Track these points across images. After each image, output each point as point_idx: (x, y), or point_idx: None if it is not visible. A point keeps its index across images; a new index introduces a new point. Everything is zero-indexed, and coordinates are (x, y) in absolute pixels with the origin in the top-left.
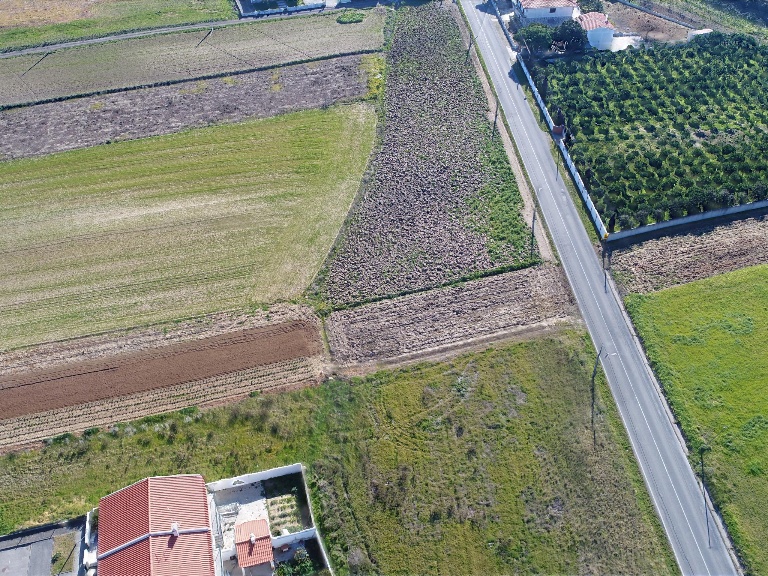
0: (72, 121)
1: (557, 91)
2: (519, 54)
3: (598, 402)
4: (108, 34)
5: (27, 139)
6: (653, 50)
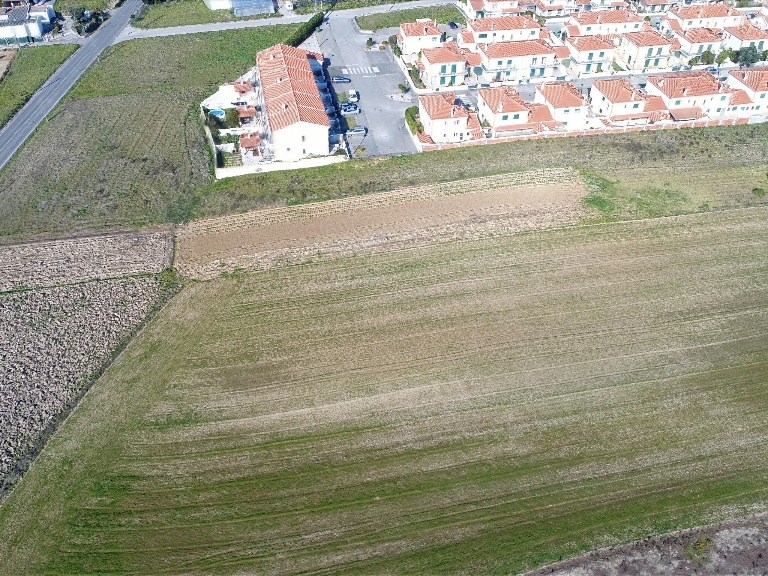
0: None
1: None
2: None
3: None
4: None
5: None
6: None
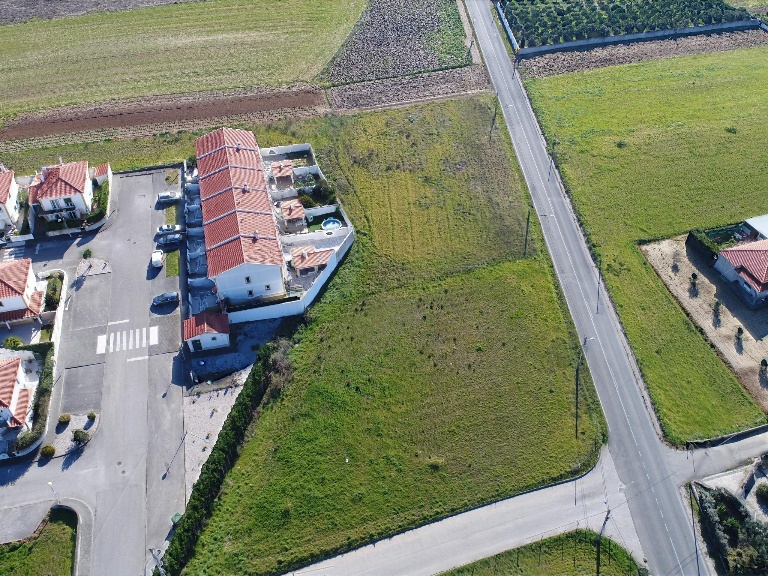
0: None
1: None
2: None
3: (496, 125)
4: None
5: (117, 1)
6: None
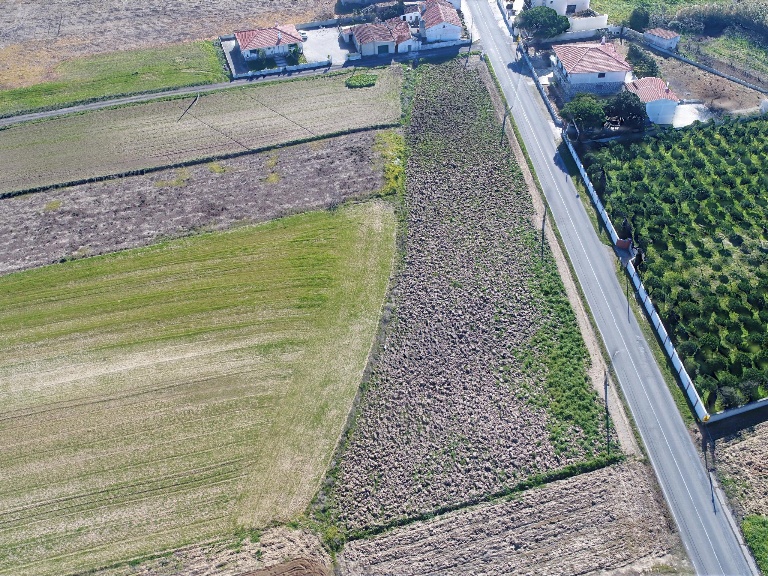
0: (21, 228)
1: (616, 185)
2: (564, 132)
3: None
4: (74, 103)
5: None
6: (724, 125)
